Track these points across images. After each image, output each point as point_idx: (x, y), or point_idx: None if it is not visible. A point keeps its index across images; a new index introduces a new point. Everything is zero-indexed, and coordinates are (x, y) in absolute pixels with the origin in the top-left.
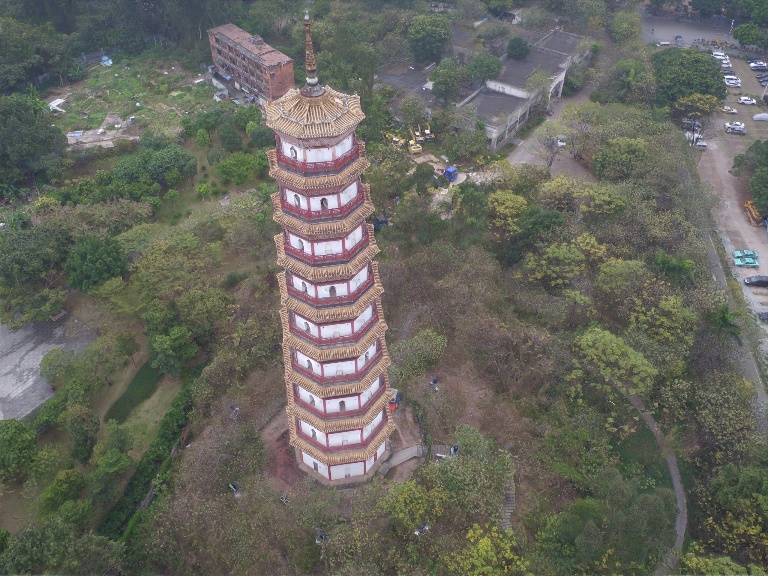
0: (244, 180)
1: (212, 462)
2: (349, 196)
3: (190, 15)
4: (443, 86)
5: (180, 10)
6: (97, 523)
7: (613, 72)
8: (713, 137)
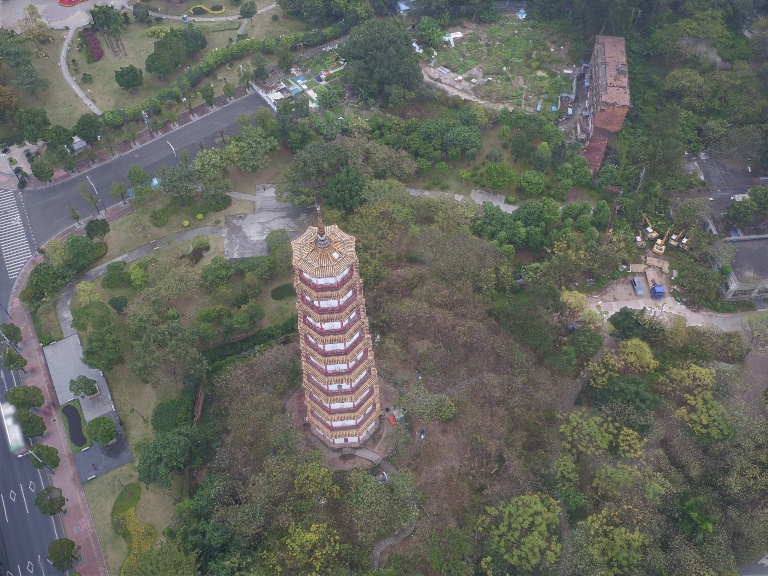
0: (496, 187)
1: (263, 366)
2: (331, 304)
3: (597, 13)
4: (733, 211)
5: (587, 7)
6: (219, 344)
7: None
8: None
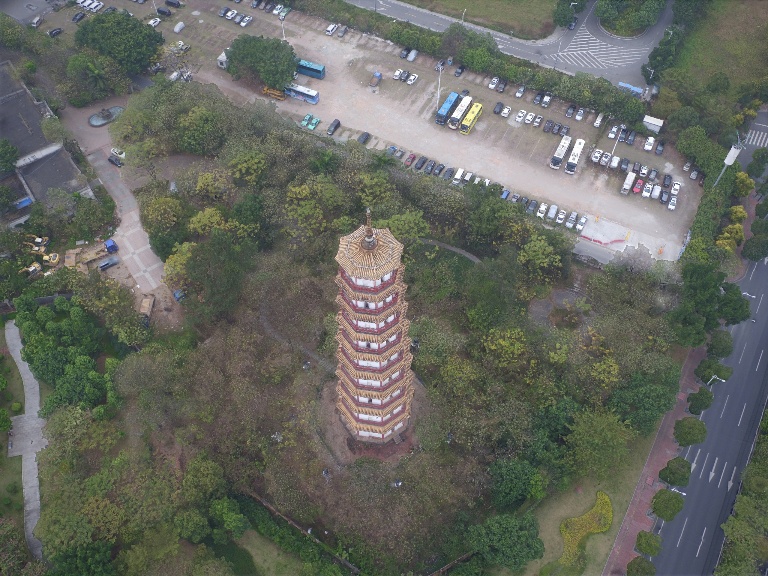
0: (9, 419)
1: None
2: None
3: None
4: (3, 198)
5: None
6: None
7: (76, 76)
8: (200, 67)
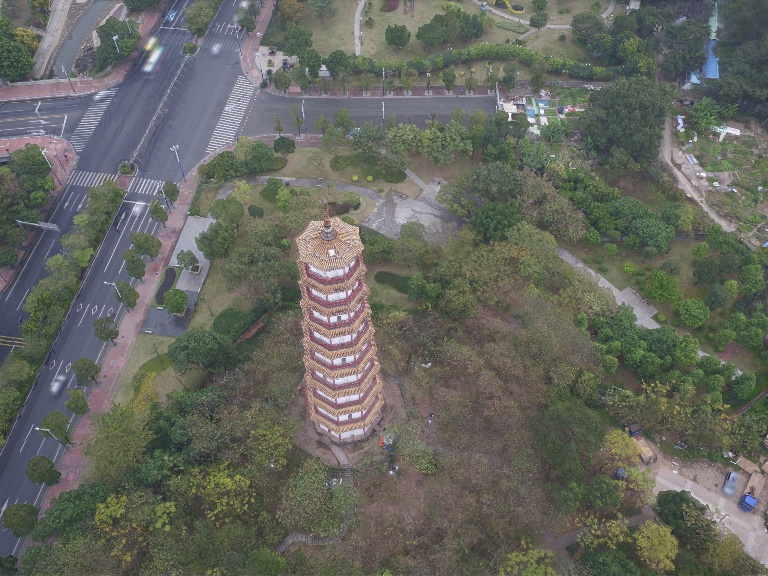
0: (651, 297)
1: None
2: None
3: None
4: None
5: None
6: None
7: None
8: None
